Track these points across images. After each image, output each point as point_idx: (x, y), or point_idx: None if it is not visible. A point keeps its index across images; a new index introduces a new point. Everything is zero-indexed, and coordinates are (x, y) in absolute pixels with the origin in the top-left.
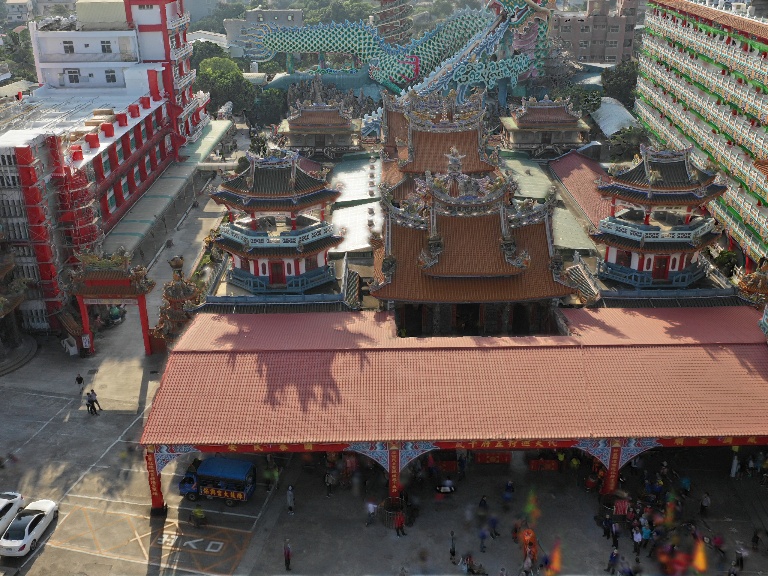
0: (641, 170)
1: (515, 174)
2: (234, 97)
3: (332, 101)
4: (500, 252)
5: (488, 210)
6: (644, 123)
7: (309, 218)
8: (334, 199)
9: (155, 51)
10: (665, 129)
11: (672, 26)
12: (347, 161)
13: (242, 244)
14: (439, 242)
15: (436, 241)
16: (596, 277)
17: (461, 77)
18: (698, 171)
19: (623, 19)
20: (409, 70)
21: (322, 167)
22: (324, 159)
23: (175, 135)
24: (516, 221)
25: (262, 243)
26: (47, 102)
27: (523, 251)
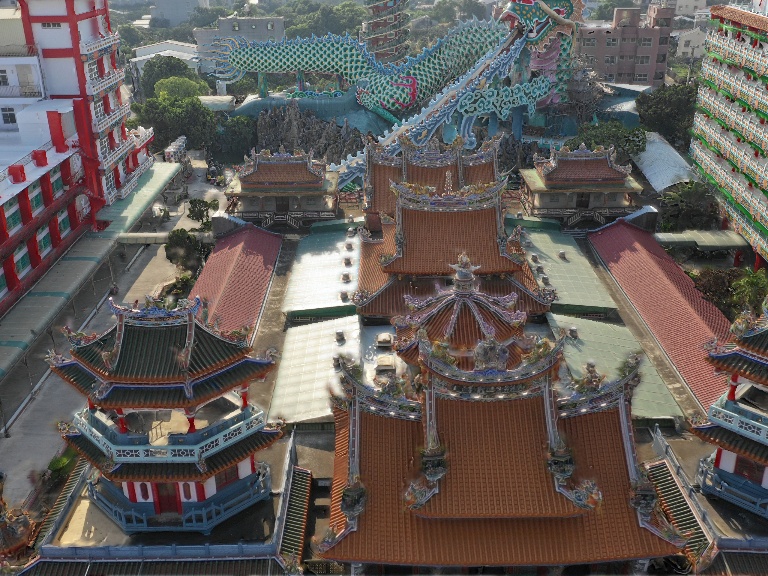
0: None
1: (545, 260)
2: (189, 129)
3: (298, 151)
4: (545, 472)
5: (523, 391)
6: (707, 175)
7: (224, 398)
8: (262, 375)
9: (66, 83)
10: (744, 191)
11: (755, 53)
12: (317, 234)
13: (104, 454)
14: (440, 459)
15: (435, 457)
16: (699, 491)
17: (467, 107)
18: None
19: (657, 31)
20: (404, 94)
21: (284, 240)
22: (287, 229)
23: (89, 196)
24: (569, 407)
25: (136, 456)
26: None
27: (588, 482)
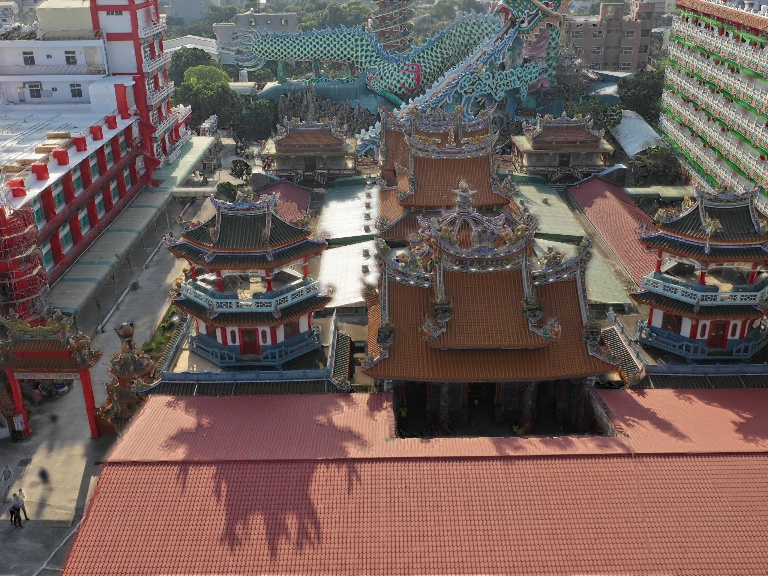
0: (695, 217)
1: (531, 204)
2: (219, 110)
3: (323, 119)
4: (522, 318)
5: (507, 265)
6: (671, 142)
7: (289, 273)
8: (319, 252)
9: (126, 62)
10: (698, 151)
11: (707, 35)
12: (340, 187)
13: (206, 308)
14: (447, 307)
15: (444, 305)
16: (637, 343)
17: (467, 88)
18: (765, 218)
19: (639, 24)
20: (410, 79)
21: (312, 193)
22: (314, 184)
23: (147, 157)
24: (541, 277)
25: (230, 307)
26: (2, 121)
27: (551, 319)
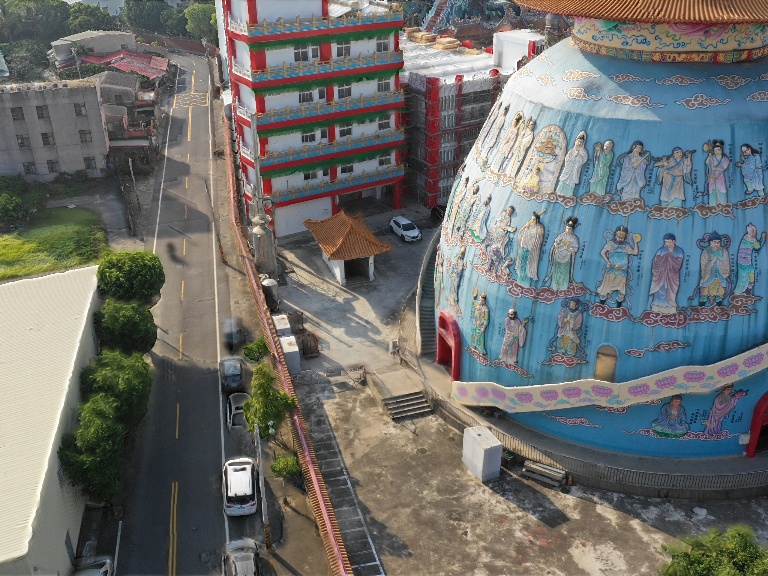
0: None
1: None
2: None
3: (474, 17)
4: None
5: None
6: None
7: None
8: None
9: None
10: None
11: None
12: None
13: None
14: None
15: None
16: None
17: (455, 0)
18: None
19: None
20: None
21: None
22: None
23: None
24: None
25: None
26: None
27: None
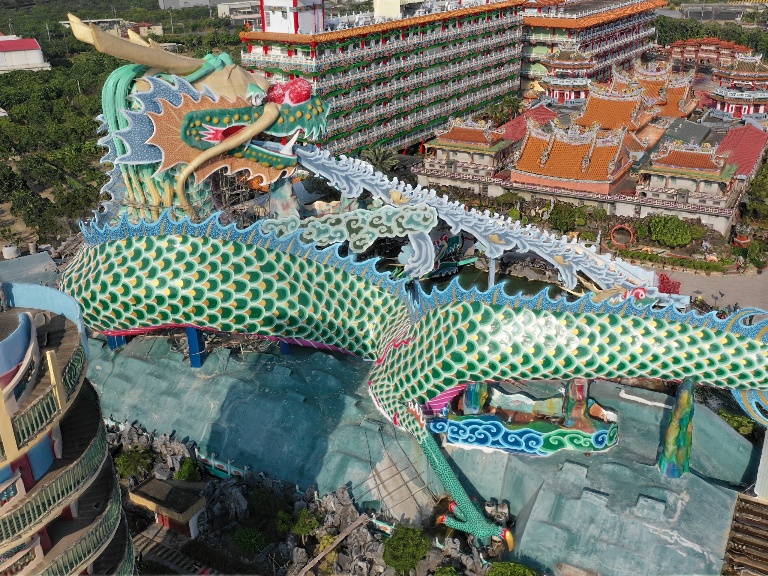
0: None
1: None
2: None
3: None
4: None
5: (642, 77)
6: None
7: None
8: None
9: None
10: None
11: None
12: None
13: None
14: None
15: None
16: None
17: None
18: None
19: None
20: None
21: None
22: None
23: None
24: None
25: None
26: None
27: None
